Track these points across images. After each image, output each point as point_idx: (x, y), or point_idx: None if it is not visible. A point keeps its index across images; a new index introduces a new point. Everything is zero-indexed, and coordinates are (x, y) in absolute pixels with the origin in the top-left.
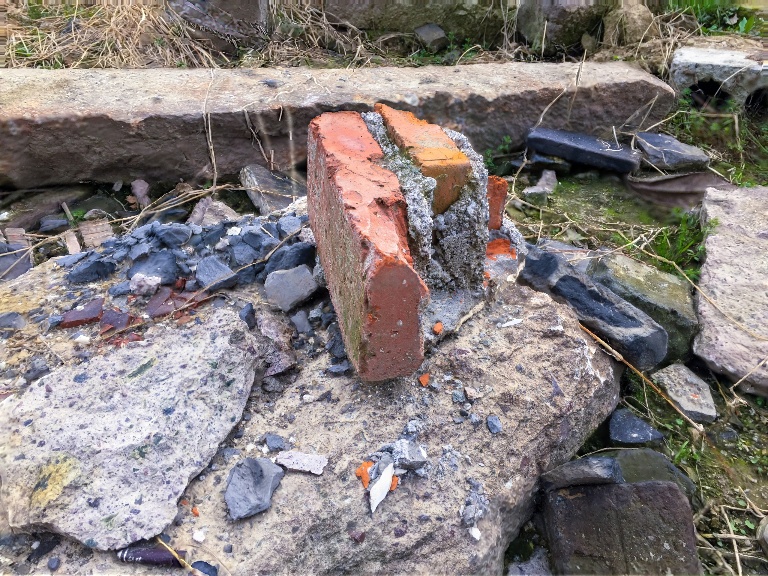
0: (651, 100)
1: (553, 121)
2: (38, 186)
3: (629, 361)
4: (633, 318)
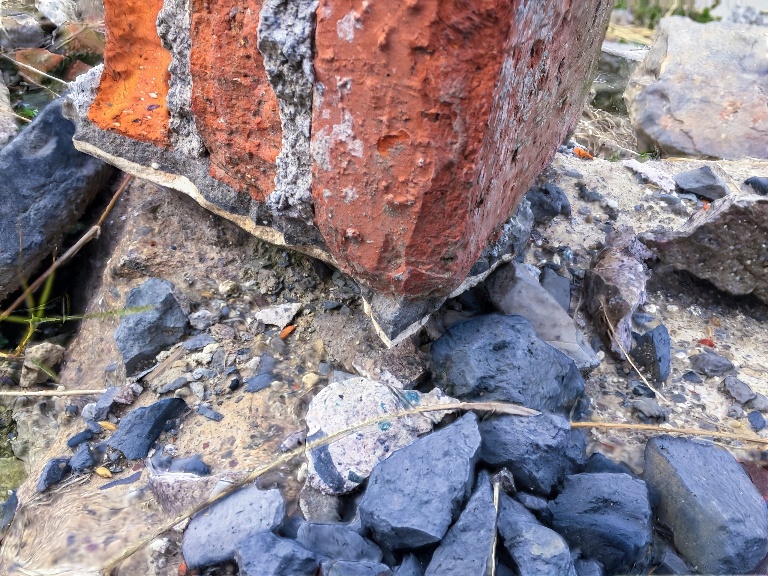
0: None
1: None
2: None
3: None
4: None
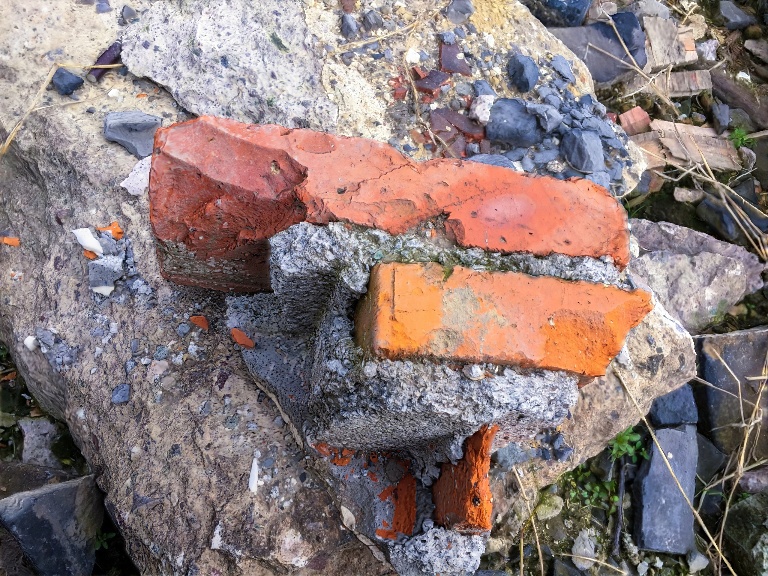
0: None
1: None
2: None
3: None
4: None
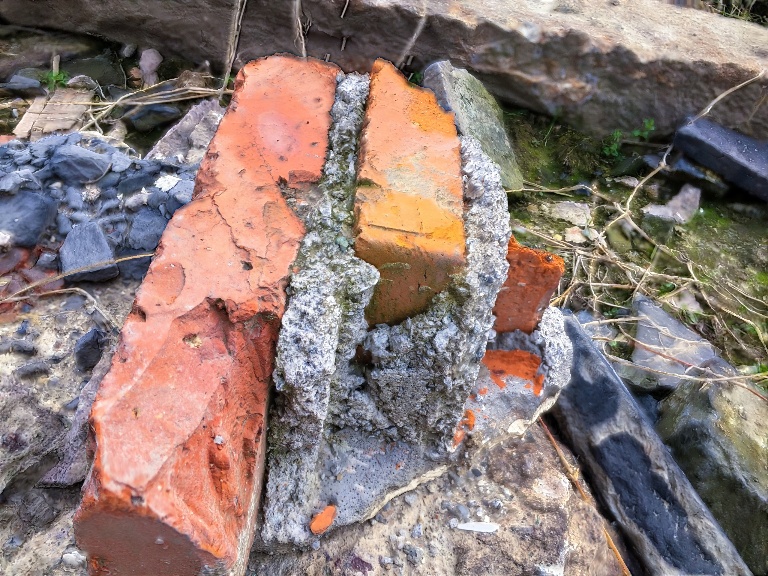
0: None
1: (727, 113)
2: (38, 25)
3: None
4: (710, 554)
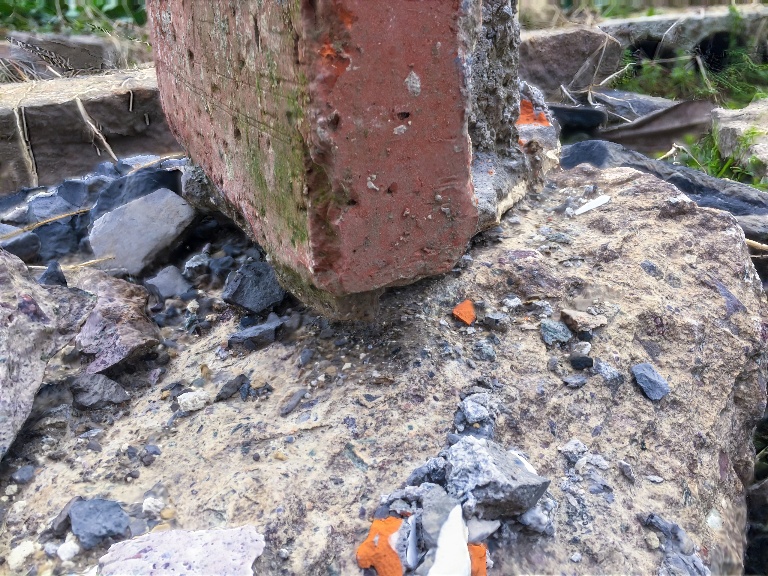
0: (601, 43)
1: None
2: None
3: (765, 282)
4: (760, 203)
